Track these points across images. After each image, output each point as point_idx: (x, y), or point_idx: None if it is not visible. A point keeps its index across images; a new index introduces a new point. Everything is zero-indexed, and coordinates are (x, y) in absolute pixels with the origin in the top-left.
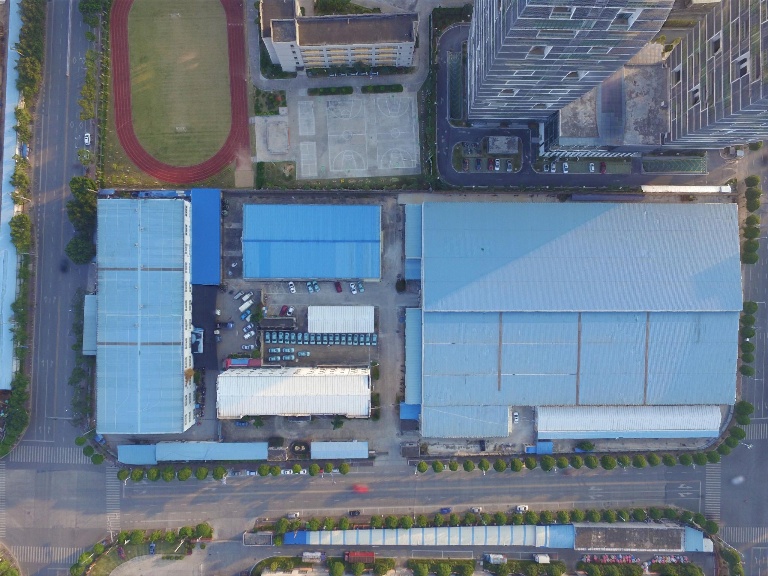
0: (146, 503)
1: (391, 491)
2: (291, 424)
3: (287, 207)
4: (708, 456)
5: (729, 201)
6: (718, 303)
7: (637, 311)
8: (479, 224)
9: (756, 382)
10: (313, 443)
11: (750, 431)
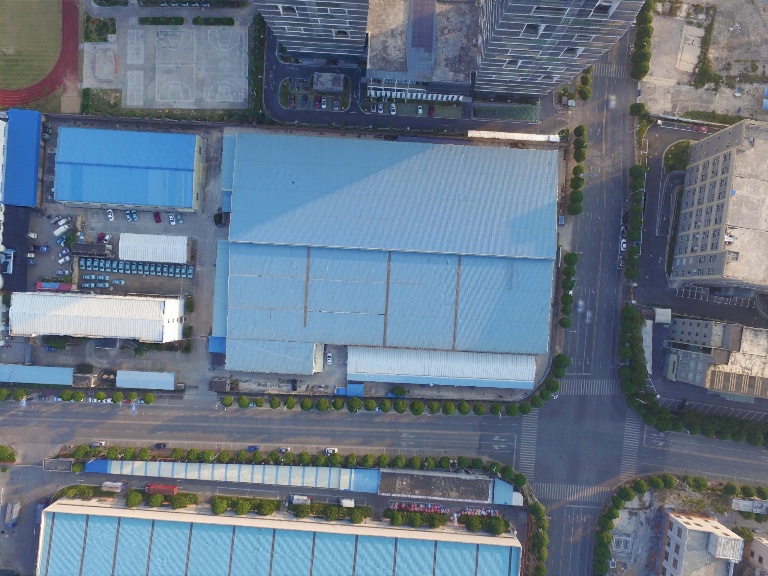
0: None
1: (199, 426)
2: (102, 352)
3: (103, 132)
4: (520, 407)
5: (561, 152)
6: (530, 249)
7: (448, 253)
8: (292, 157)
9: (578, 337)
10: (119, 371)
11: (570, 386)
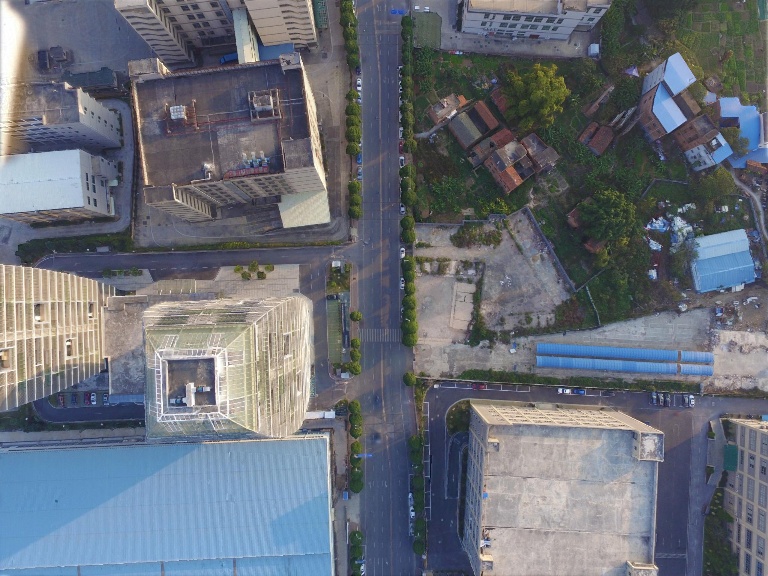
0: None
1: None
2: None
3: None
4: None
5: (342, 422)
6: (303, 547)
7: None
8: (54, 474)
9: None
10: None
11: None
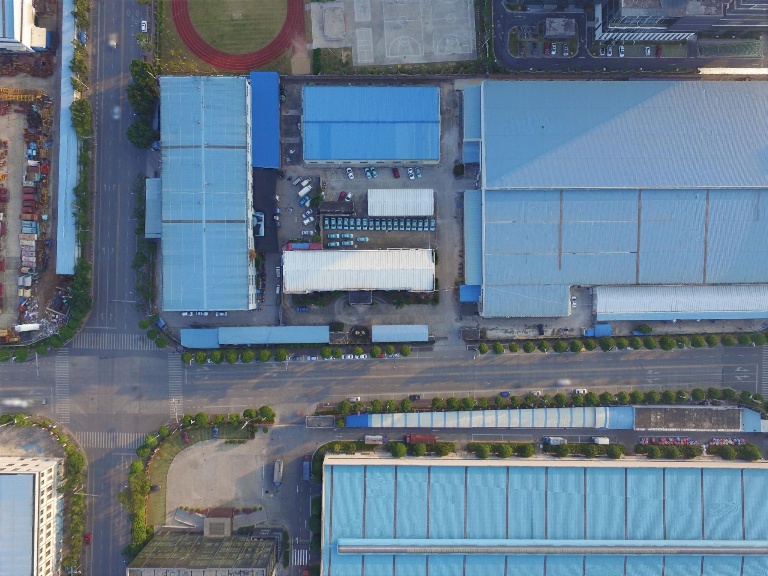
0: (208, 389)
1: (450, 376)
2: (351, 310)
3: (346, 89)
4: (766, 336)
5: None
6: None
7: (697, 188)
8: (539, 102)
9: None
10: (374, 326)
11: None
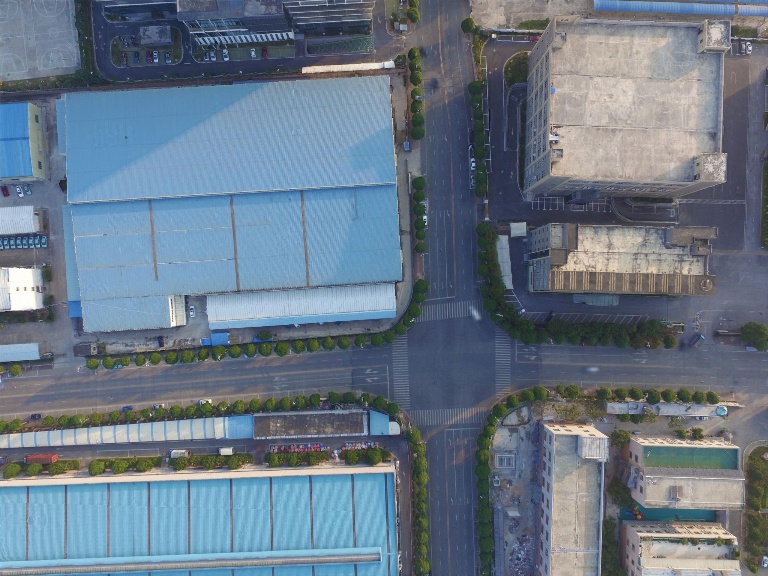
0: None
1: (72, 393)
2: None
3: None
4: (384, 336)
5: (400, 79)
6: (370, 176)
7: (289, 190)
8: (122, 113)
9: (439, 261)
10: None
11: (435, 311)
